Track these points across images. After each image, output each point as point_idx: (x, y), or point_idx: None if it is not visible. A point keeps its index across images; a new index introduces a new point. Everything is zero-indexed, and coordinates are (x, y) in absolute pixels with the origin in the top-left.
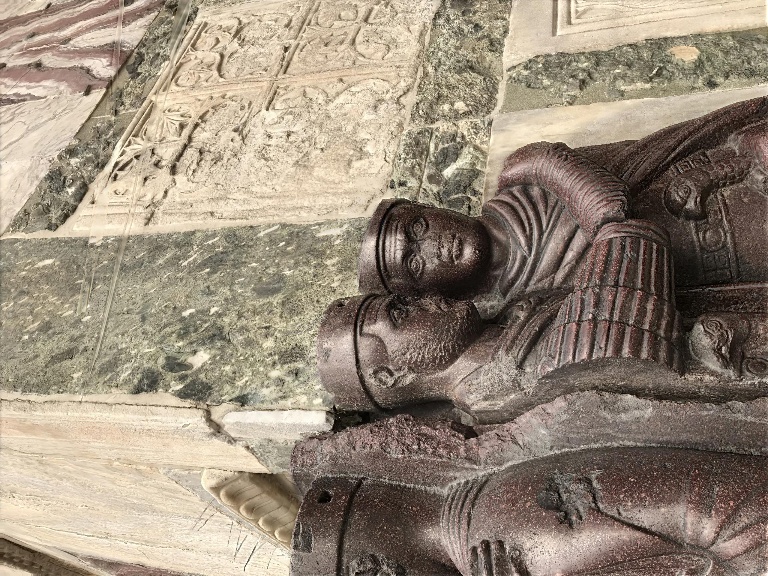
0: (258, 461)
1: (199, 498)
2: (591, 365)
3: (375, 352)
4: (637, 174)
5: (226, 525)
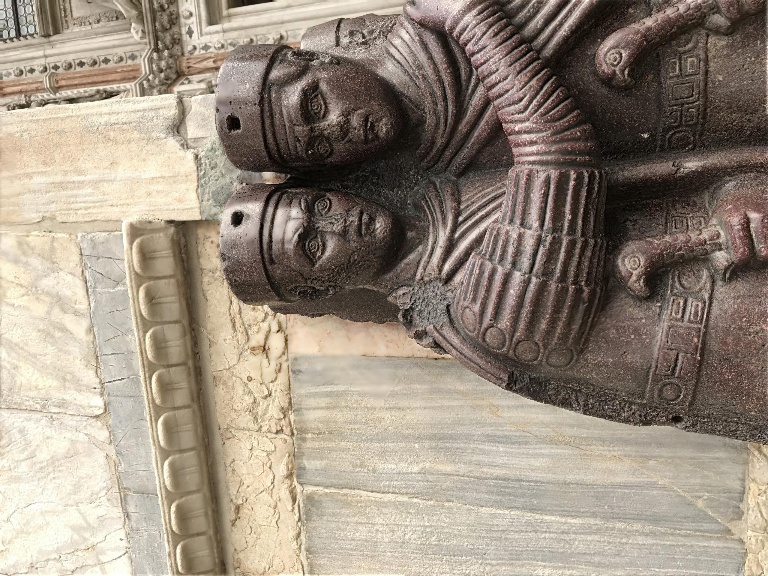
0: (196, 190)
1: (90, 318)
2: None
3: (355, 21)
4: None
5: (85, 425)
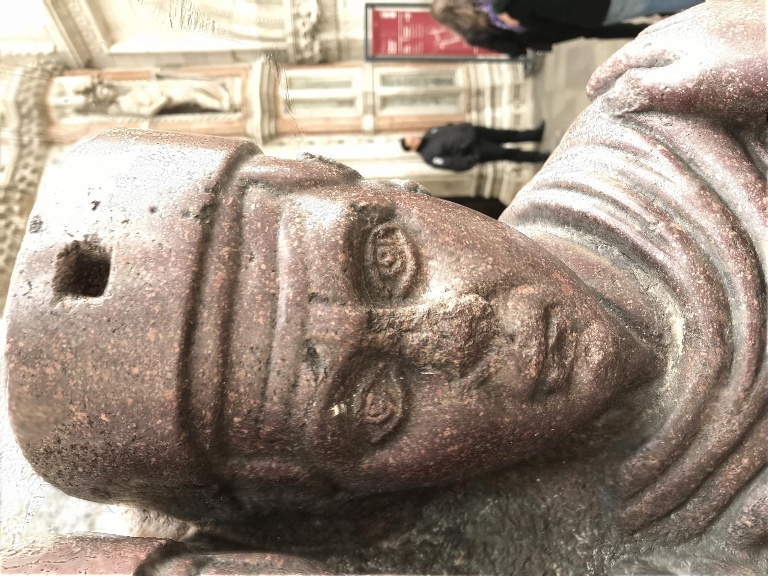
0: None
1: None
2: None
3: None
4: None
5: None
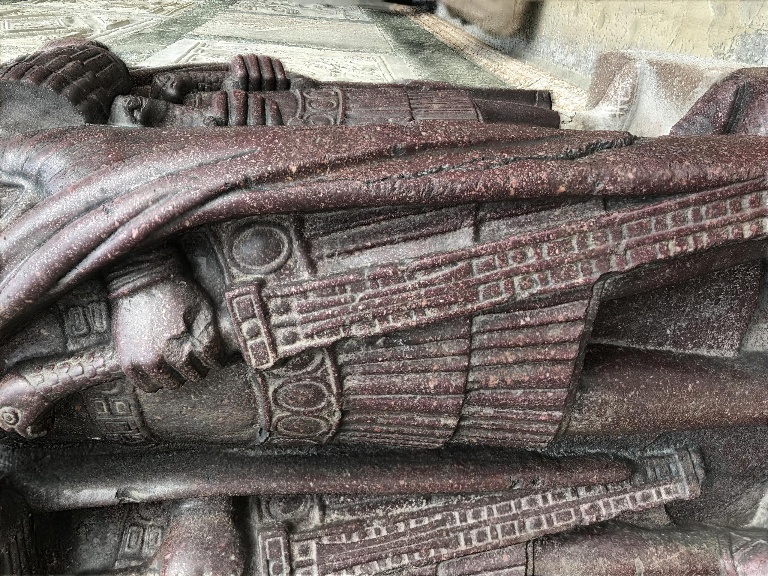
0: None
1: None
2: None
3: None
4: (131, 71)
5: None
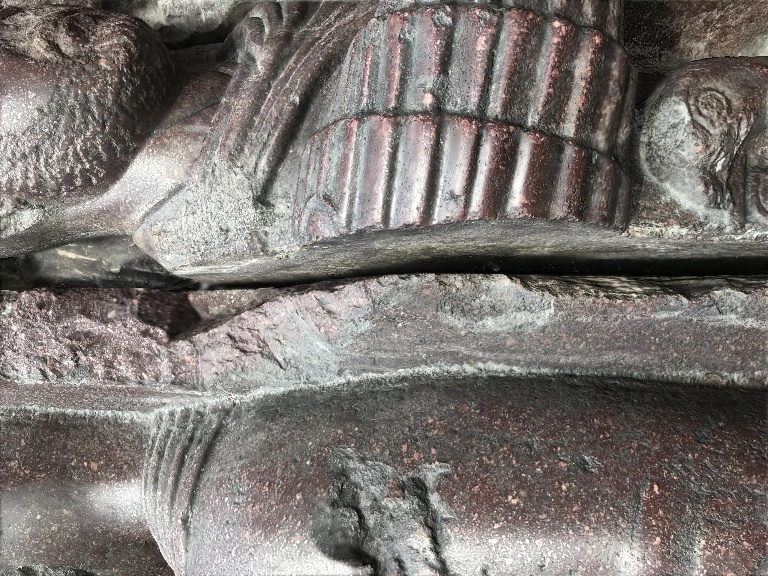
0: None
1: None
2: (427, 230)
3: None
4: None
5: None
